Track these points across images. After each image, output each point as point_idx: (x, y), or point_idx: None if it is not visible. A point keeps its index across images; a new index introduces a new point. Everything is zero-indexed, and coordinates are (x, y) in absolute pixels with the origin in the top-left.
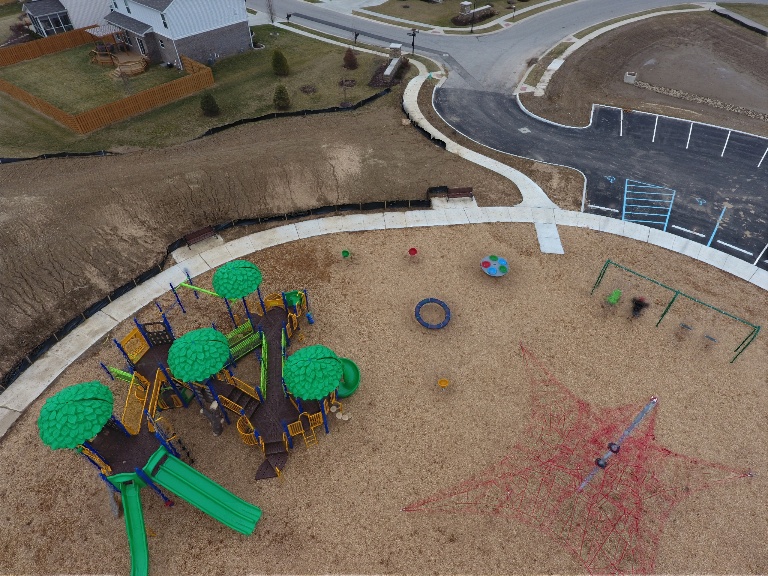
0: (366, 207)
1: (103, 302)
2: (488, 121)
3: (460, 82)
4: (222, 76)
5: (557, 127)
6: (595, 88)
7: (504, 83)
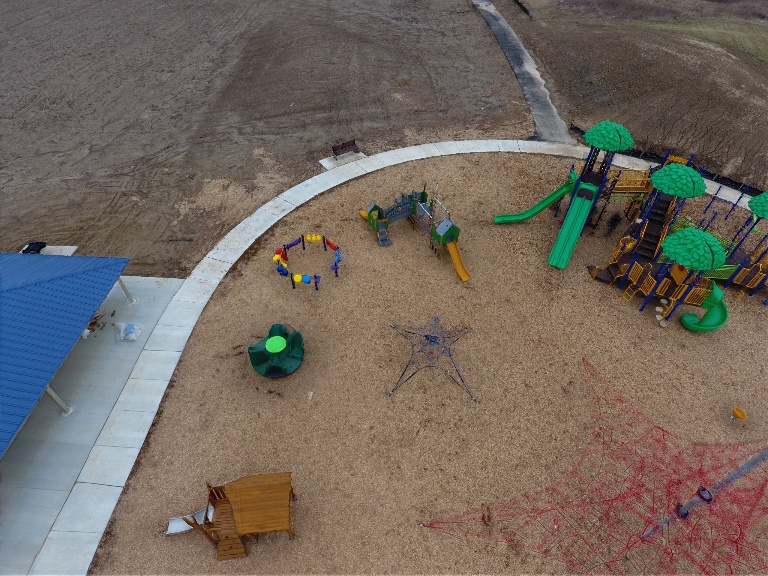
0: None
1: (710, 175)
2: None
3: None
4: None
5: None
6: None
7: None
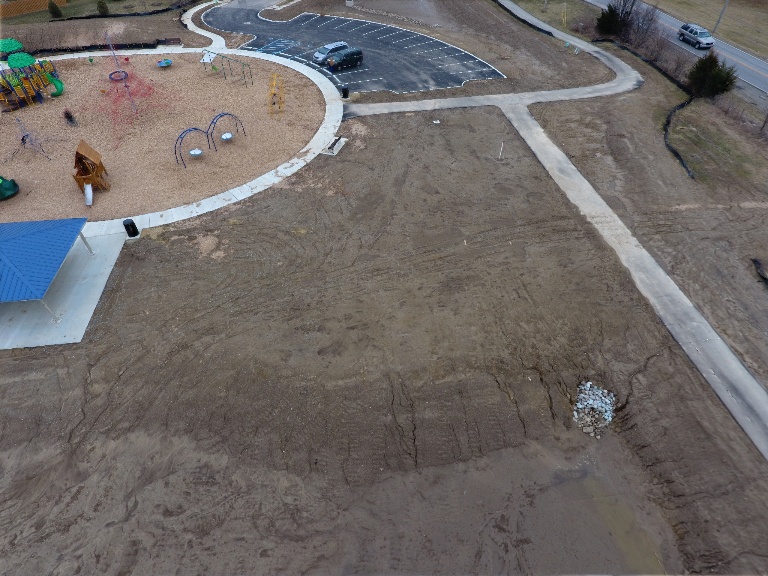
0: (117, 47)
1: None
2: (230, 20)
3: (234, 5)
4: (75, 0)
5: (269, 22)
6: (318, 7)
7: (262, 5)
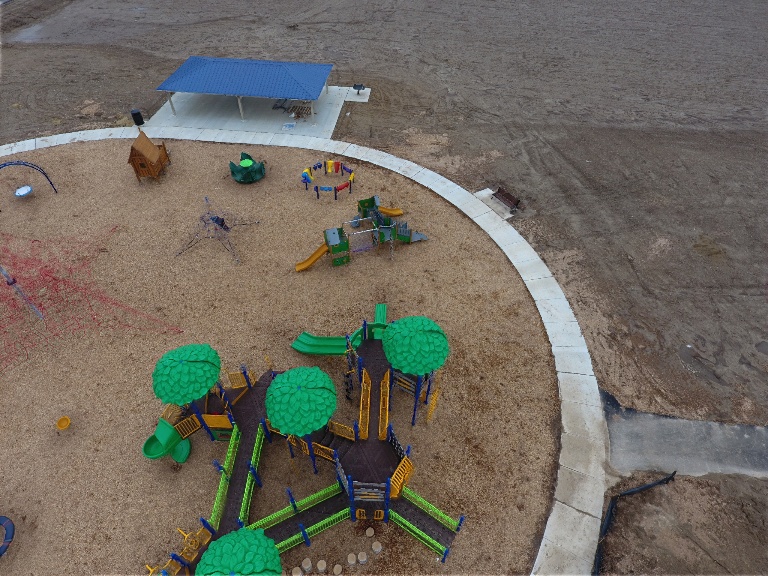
0: None
1: None
2: None
3: None
4: None
5: None
6: None
7: None
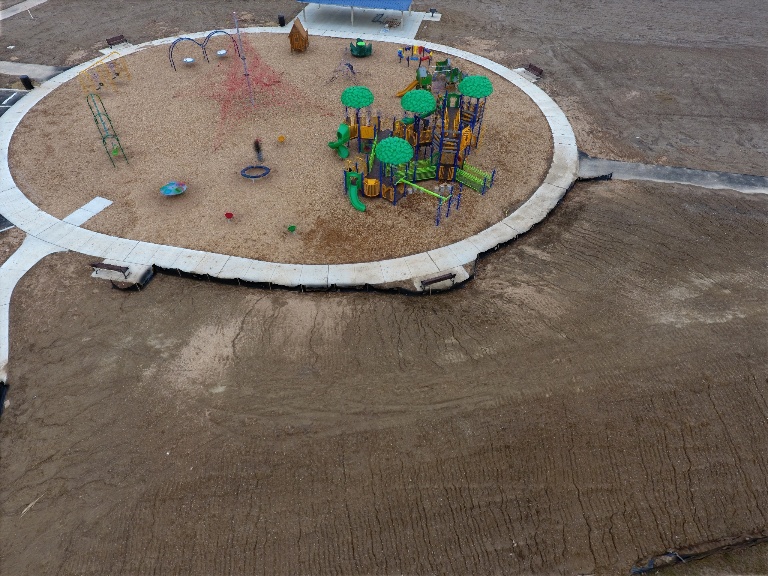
0: (232, 283)
1: None
2: None
3: None
4: None
5: None
6: None
7: None
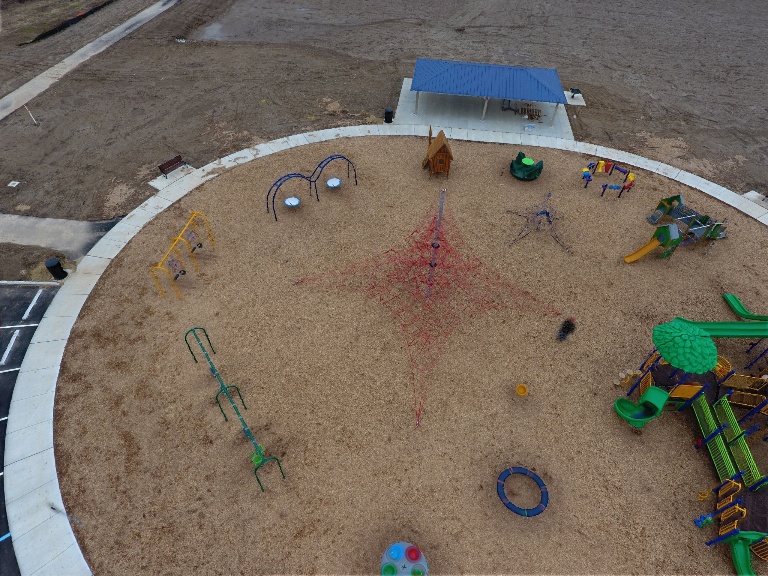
0: None
1: None
2: None
3: None
4: None
5: None
6: None
7: None
